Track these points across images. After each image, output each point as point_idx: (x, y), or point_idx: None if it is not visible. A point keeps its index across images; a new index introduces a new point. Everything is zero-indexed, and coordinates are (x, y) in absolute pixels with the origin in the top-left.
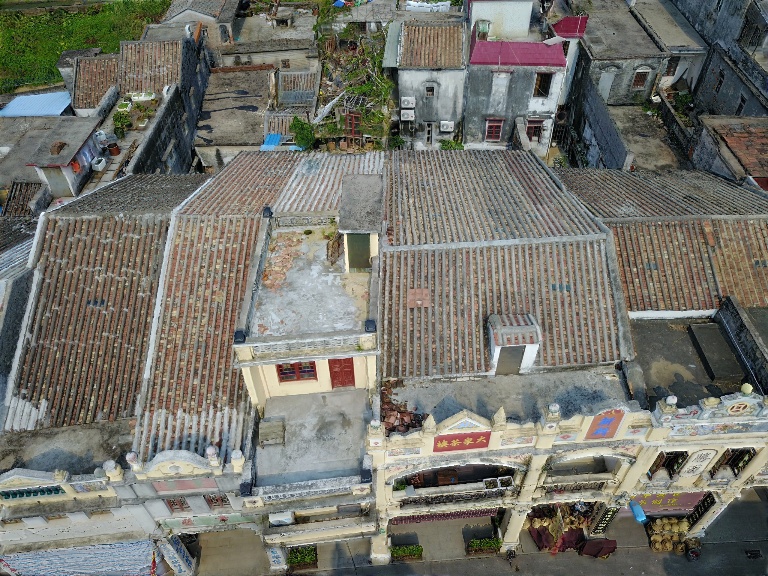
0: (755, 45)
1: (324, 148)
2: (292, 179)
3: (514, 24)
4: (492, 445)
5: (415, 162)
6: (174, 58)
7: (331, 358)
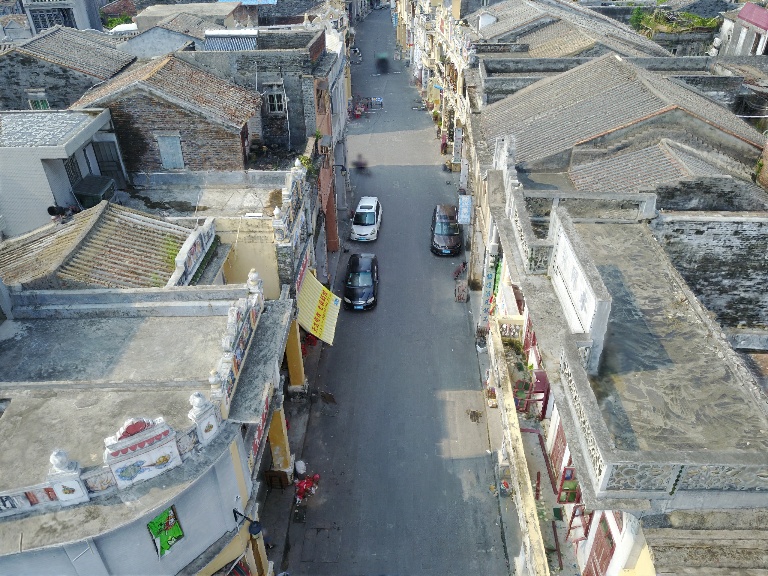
0: None
1: (640, 32)
2: (578, 6)
3: None
4: None
5: None
6: None
7: None
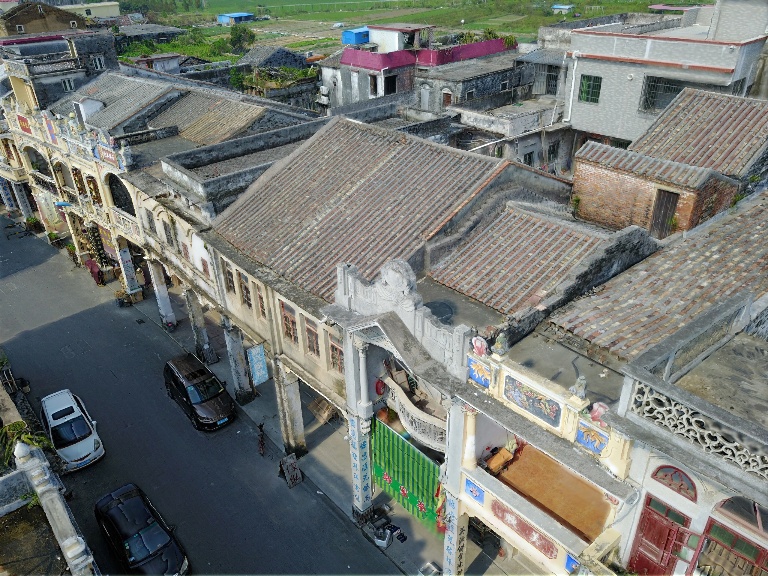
0: (553, 94)
1: (246, 92)
2: None
3: (390, 49)
4: (32, 133)
5: (252, 97)
6: (267, 55)
7: (20, 76)
